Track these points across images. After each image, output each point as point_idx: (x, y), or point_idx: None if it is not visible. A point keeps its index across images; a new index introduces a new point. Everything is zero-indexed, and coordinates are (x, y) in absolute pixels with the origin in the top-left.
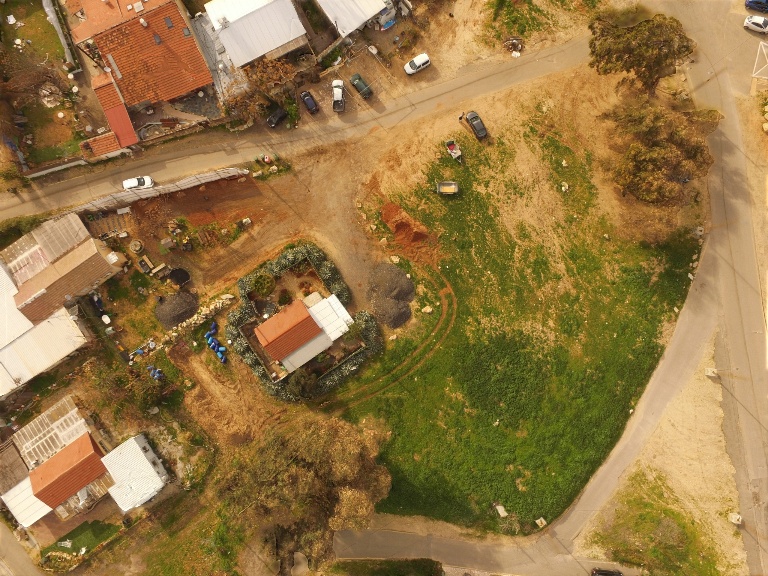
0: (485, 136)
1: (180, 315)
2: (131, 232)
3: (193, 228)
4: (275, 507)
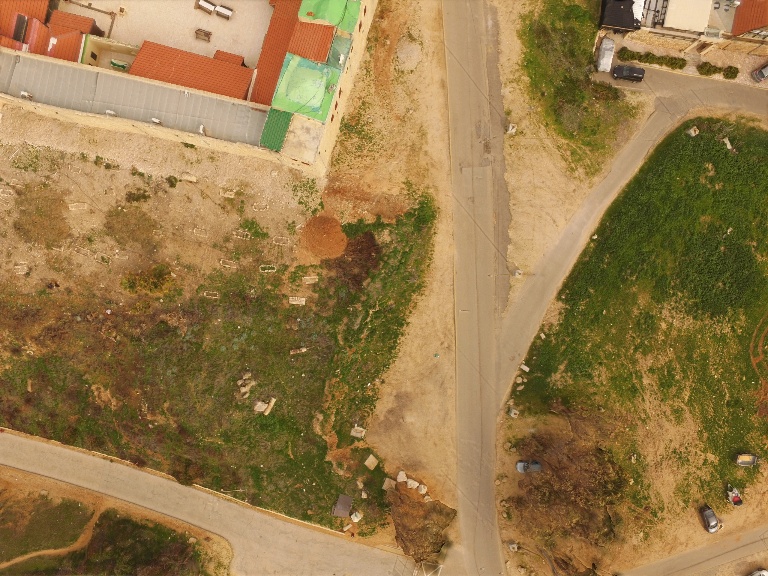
0: (703, 509)
1: None
2: None
3: None
4: None
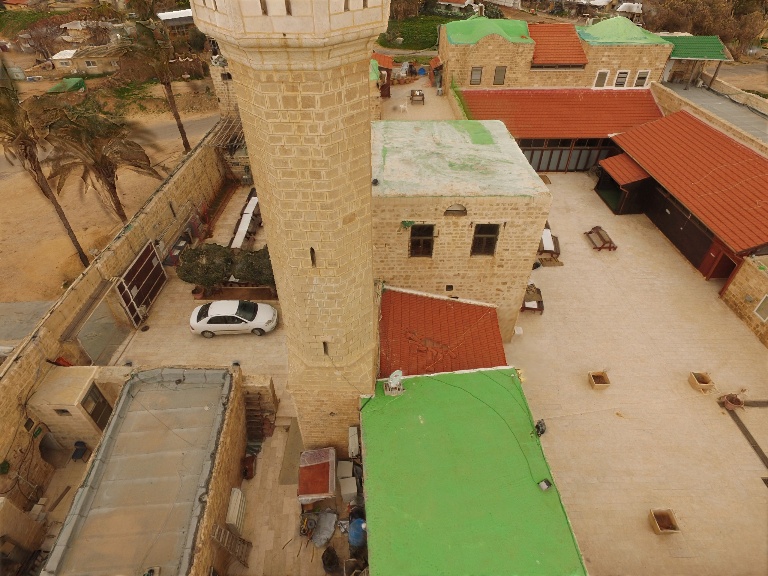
0: None
1: None
2: None
3: None
4: None
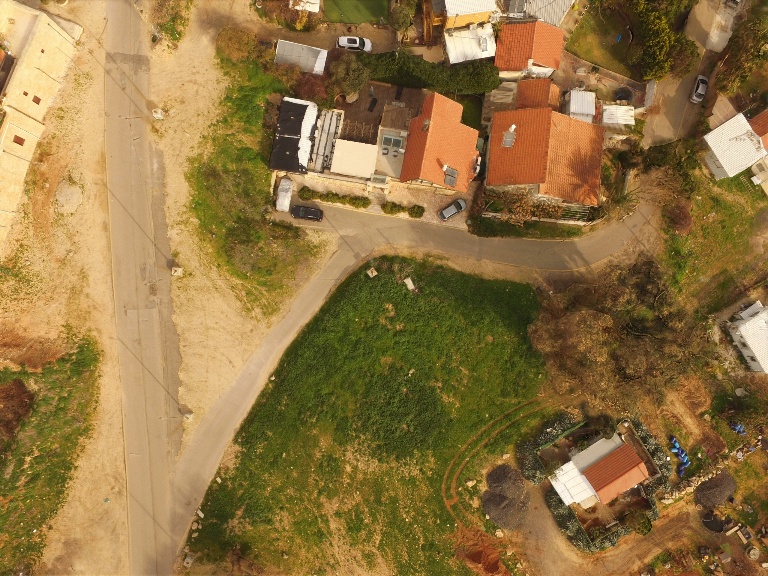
0: None
1: (715, 486)
2: (758, 567)
3: (697, 569)
4: (653, 325)
